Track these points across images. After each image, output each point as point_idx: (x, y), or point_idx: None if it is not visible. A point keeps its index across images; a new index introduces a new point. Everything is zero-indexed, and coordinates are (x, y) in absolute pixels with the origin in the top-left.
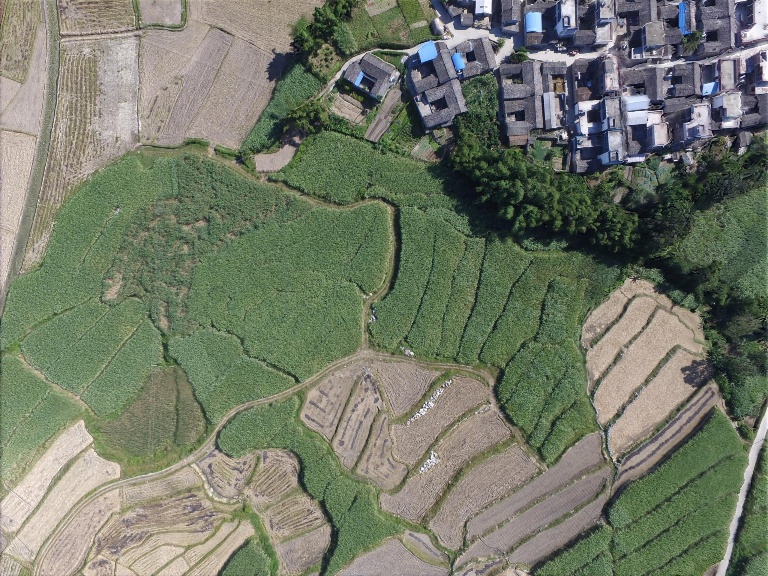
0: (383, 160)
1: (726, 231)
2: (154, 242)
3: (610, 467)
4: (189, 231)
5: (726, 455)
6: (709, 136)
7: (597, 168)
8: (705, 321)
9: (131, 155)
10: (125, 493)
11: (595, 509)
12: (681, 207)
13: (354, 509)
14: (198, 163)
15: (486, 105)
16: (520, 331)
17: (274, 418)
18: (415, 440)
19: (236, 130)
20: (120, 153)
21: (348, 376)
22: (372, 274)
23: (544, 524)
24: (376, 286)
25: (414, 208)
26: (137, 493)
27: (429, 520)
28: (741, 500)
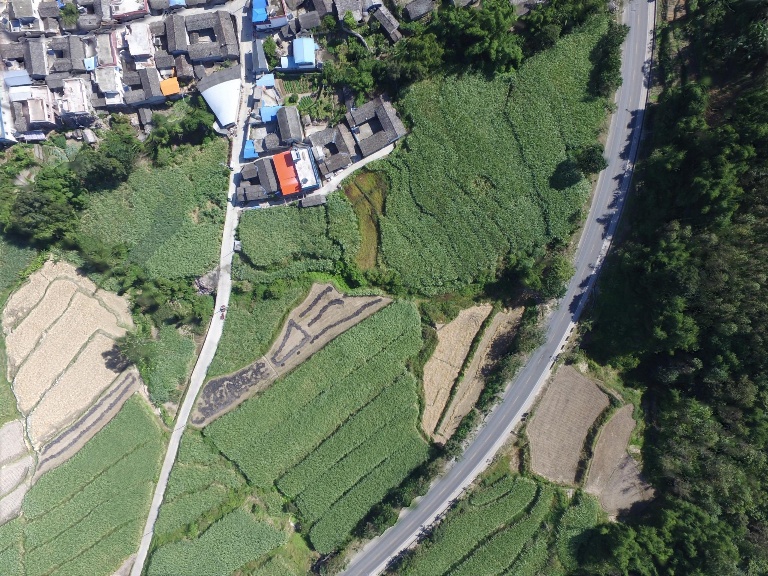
0: None
1: (134, 211)
2: None
3: (32, 456)
4: None
5: (141, 442)
6: (83, 112)
7: None
8: (137, 305)
9: None
10: None
11: (15, 500)
12: (52, 185)
13: None
14: None
15: None
16: None
17: None
18: None
19: None
20: None
21: None
22: None
23: None
24: None
25: None
26: None
27: None
28: (161, 489)
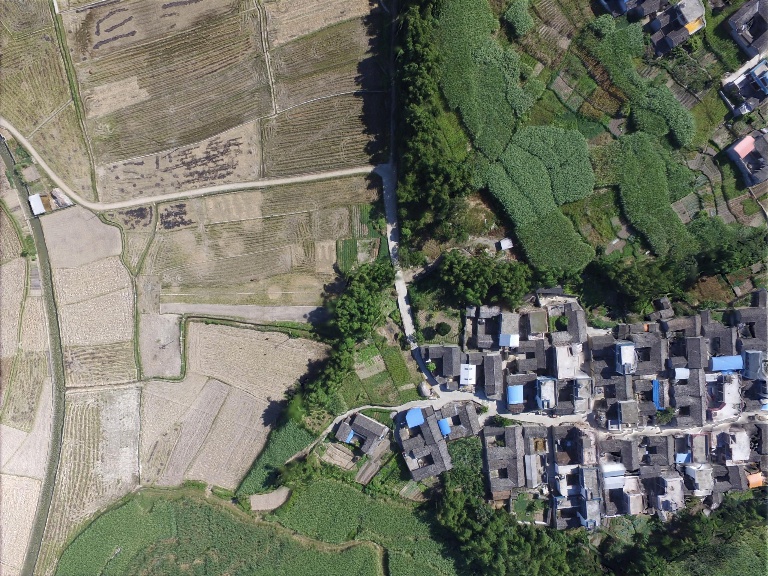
0: (372, 506)
1: None
2: None
3: None
4: (187, 572)
5: None
6: None
7: (576, 526)
8: None
9: (132, 497)
10: None
11: None
12: None
13: None
14: (196, 509)
15: (471, 461)
16: None
17: None
18: None
19: (232, 471)
20: (121, 494)
21: None
22: None
23: None
24: None
25: (402, 554)
26: None
27: None
28: None
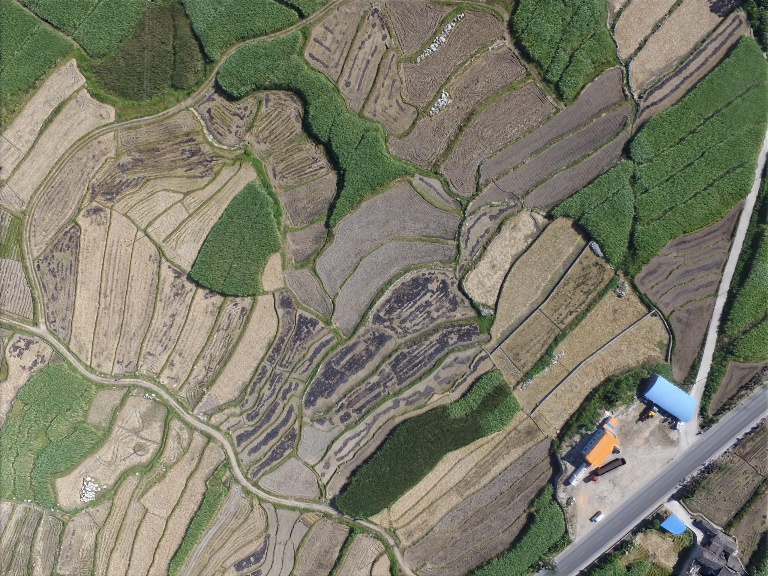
0: None
1: None
2: None
3: (631, 104)
4: None
5: (754, 83)
6: None
7: None
8: None
9: None
10: (120, 137)
11: (615, 148)
12: None
13: (361, 146)
14: None
15: None
16: None
17: (276, 51)
18: (425, 80)
19: None
20: None
21: (354, 11)
22: None
23: (561, 167)
24: None
25: None
26: (133, 138)
27: (440, 164)
28: None
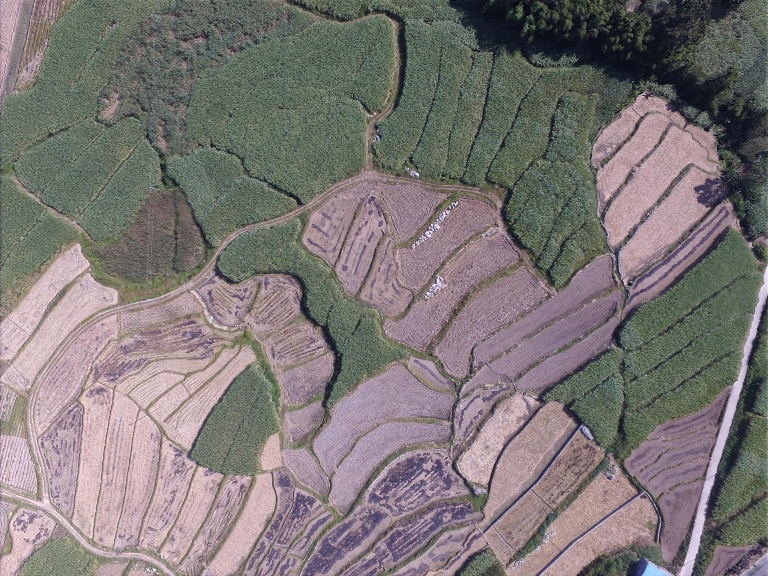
0: None
1: (742, 41)
2: (151, 57)
3: (621, 290)
4: (187, 46)
5: (740, 274)
6: None
7: None
8: (719, 142)
9: None
10: (123, 319)
11: (605, 333)
12: (696, 5)
13: (358, 332)
14: None
15: None
16: (529, 149)
17: (275, 239)
18: (420, 264)
19: None
20: None
21: (351, 198)
22: (376, 90)
23: (553, 350)
24: (380, 103)
25: (419, 20)
26: (135, 320)
27: (435, 346)
28: (755, 322)
